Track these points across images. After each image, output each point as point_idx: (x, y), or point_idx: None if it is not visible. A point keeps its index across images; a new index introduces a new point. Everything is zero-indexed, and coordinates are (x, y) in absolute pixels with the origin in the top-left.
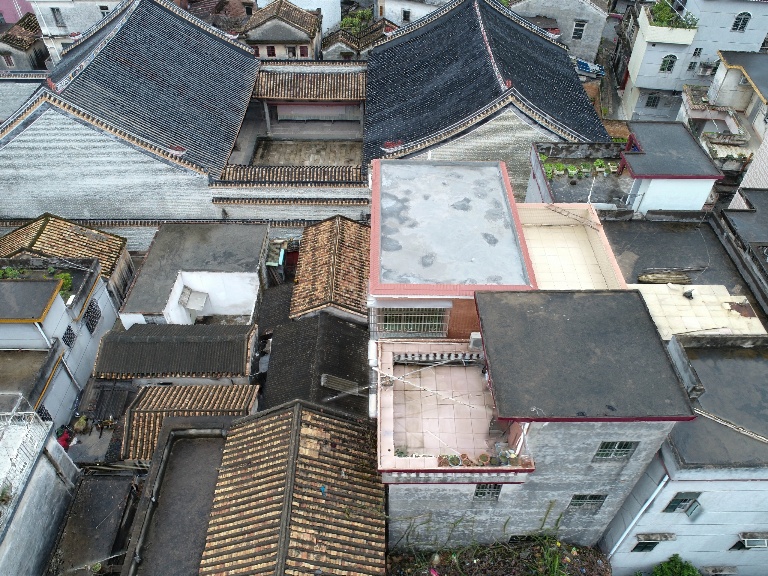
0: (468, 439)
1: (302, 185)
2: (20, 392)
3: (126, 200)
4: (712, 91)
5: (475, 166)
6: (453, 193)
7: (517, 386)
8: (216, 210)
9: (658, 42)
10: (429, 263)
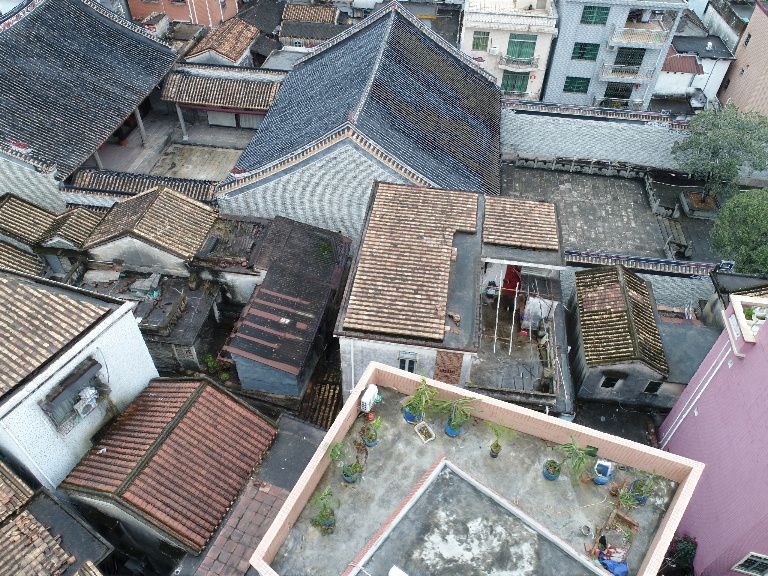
0: None
1: None
2: None
3: None
4: None
5: None
6: None
7: None
8: None
9: None
10: None
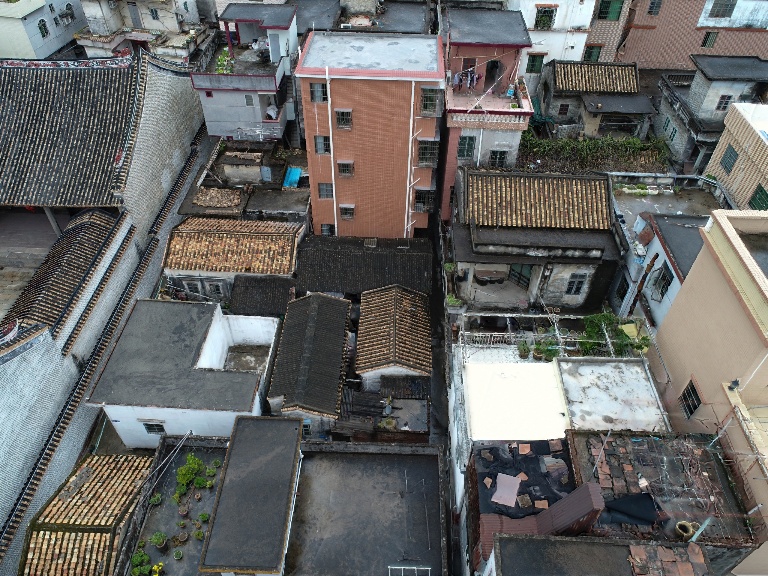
0: (498, 103)
1: (100, 257)
2: (359, 472)
3: (4, 458)
4: (96, 26)
5: (312, 41)
6: (344, 50)
7: (513, 40)
8: (68, 364)
9: (27, 14)
10: (416, 61)
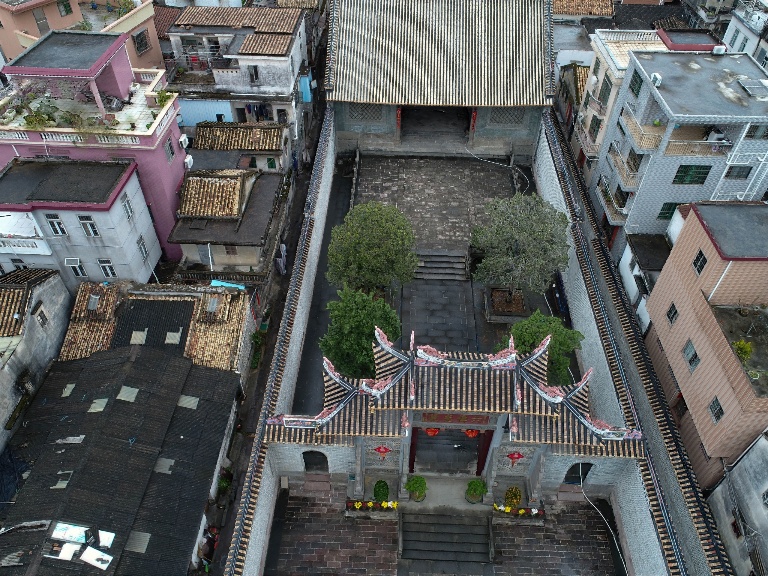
0: None
1: None
2: None
3: None
4: None
5: None
6: None
7: None
8: None
9: None
10: None
